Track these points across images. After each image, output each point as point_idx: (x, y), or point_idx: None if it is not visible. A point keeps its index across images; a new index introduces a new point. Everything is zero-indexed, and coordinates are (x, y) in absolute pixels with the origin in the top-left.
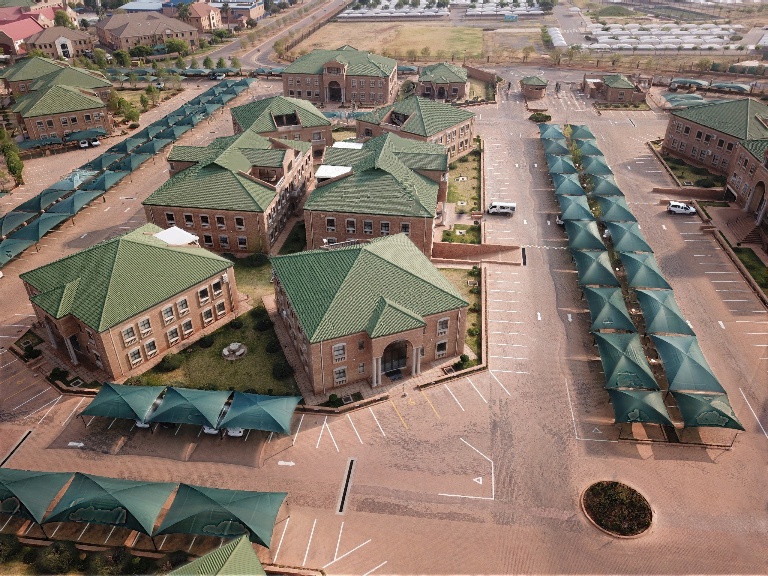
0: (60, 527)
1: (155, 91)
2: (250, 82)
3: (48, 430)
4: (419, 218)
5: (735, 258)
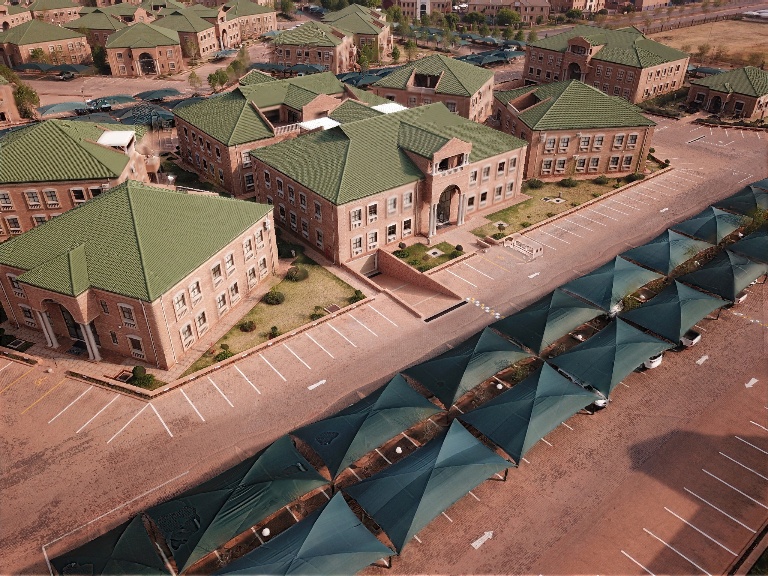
0: None
1: (412, 46)
2: (514, 55)
3: None
4: (327, 200)
5: None
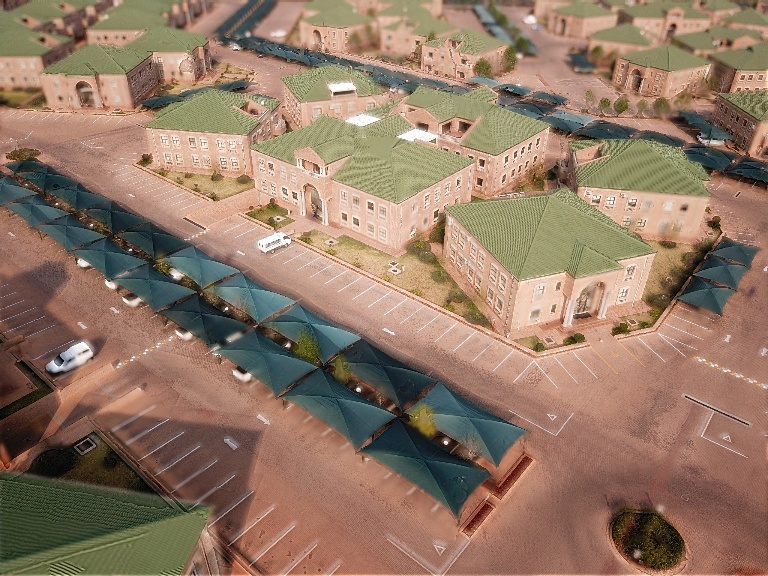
0: None
1: None
2: None
3: None
4: None
5: None
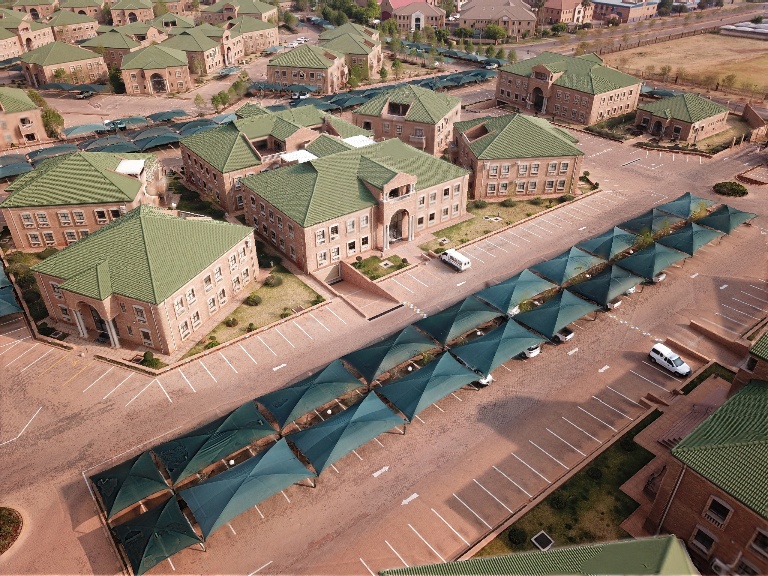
0: None
1: None
2: (491, 75)
3: None
4: None
5: None
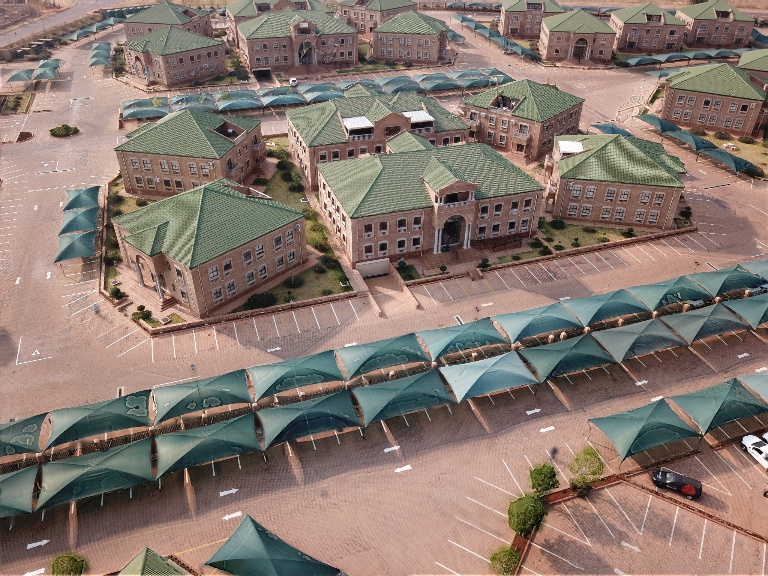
0: (708, 159)
1: None
2: None
3: (696, 184)
4: None
5: (353, 73)
